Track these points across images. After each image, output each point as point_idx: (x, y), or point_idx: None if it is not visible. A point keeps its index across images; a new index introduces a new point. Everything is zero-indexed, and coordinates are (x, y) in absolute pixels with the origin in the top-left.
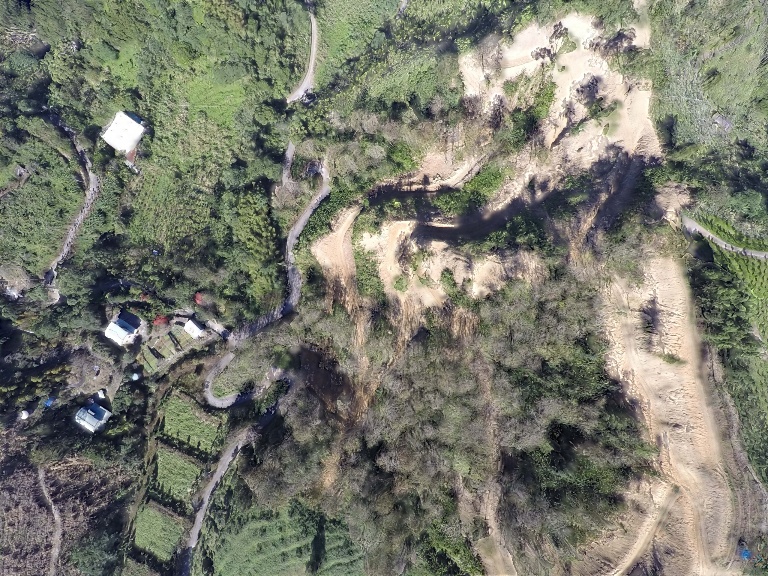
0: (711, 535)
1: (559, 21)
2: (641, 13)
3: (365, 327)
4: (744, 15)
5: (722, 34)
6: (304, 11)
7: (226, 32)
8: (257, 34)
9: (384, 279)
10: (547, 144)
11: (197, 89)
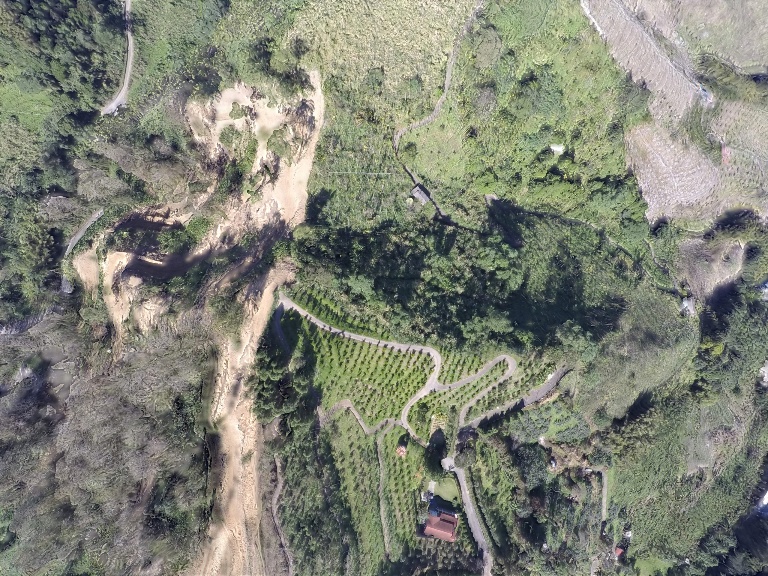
0: None
1: None
2: (316, 87)
3: (68, 345)
4: (425, 98)
5: (411, 113)
6: (106, 31)
7: (15, 48)
8: (53, 51)
9: (106, 302)
10: (244, 199)
11: (9, 95)
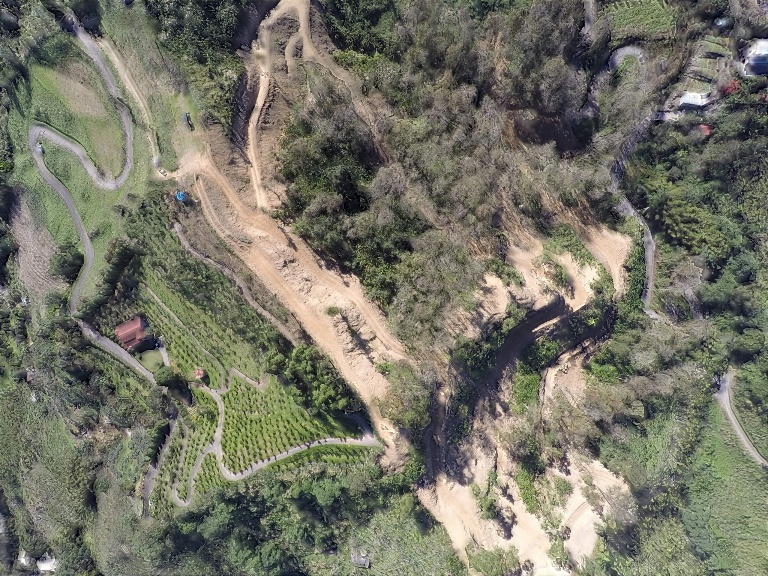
0: (220, 192)
1: (571, 573)
2: None
3: (557, 193)
4: None
5: None
6: None
7: None
8: None
9: None
10: (502, 453)
11: None
